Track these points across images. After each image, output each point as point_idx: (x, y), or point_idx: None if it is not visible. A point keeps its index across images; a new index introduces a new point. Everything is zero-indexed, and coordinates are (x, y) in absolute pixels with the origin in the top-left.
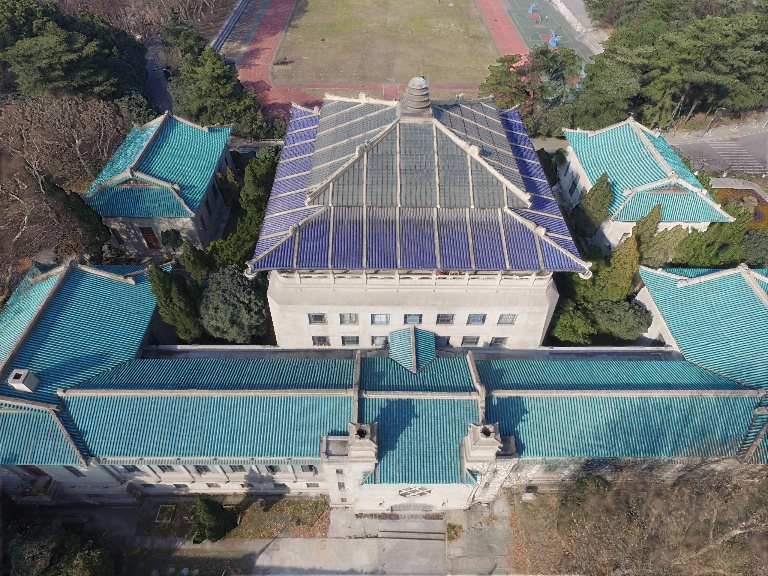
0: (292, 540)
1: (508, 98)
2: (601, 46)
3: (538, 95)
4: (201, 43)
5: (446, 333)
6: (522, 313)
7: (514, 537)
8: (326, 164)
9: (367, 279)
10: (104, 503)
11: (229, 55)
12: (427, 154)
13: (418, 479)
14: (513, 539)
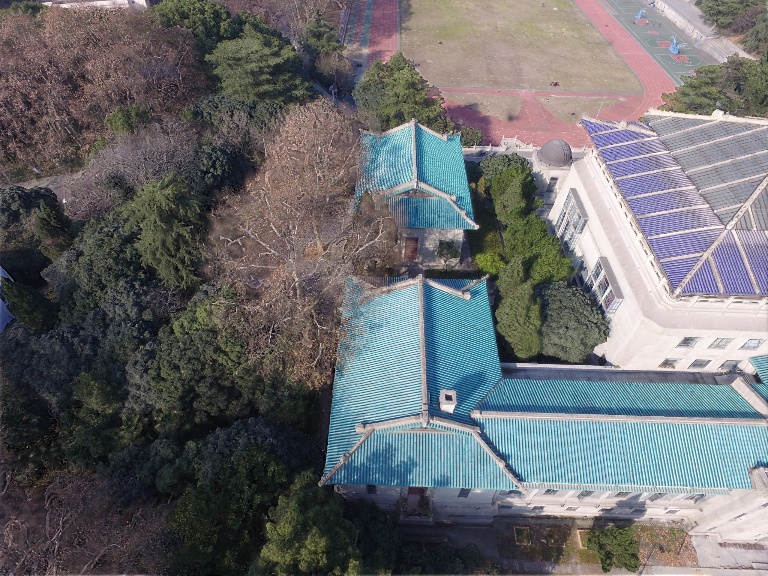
0: (664, 568)
1: (703, 109)
2: (728, 54)
3: (727, 106)
4: (342, 45)
5: None
6: None
7: None
8: (721, 185)
9: (764, 304)
10: (457, 523)
11: (353, 57)
12: None
13: None
14: None
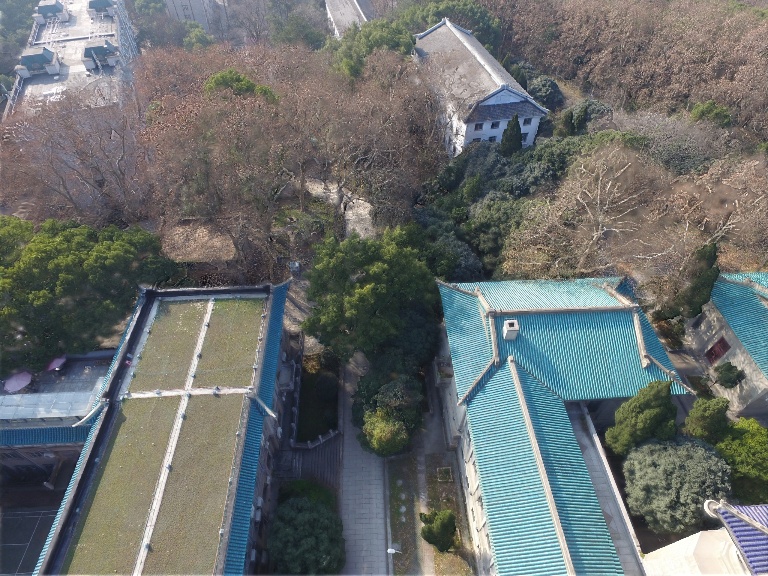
0: None
1: None
2: None
3: None
4: None
5: None
6: None
7: None
8: None
9: None
10: (445, 420)
11: None
12: None
13: None
14: None
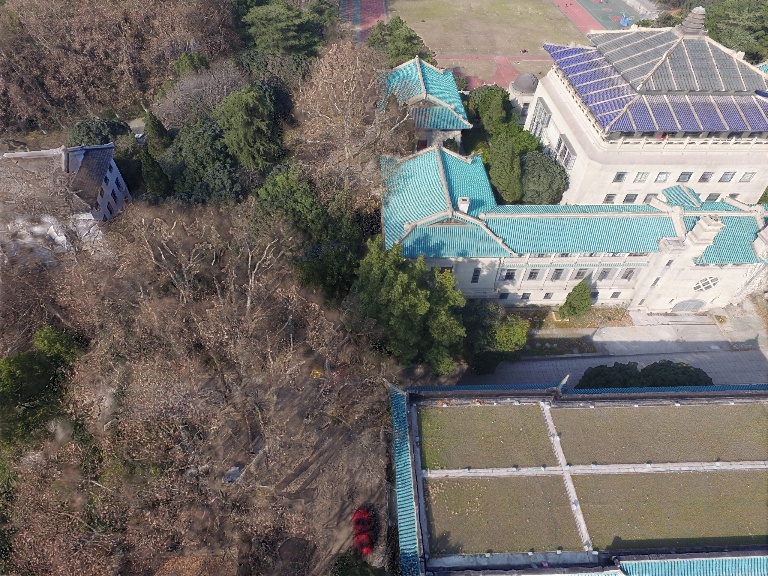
0: (611, 328)
1: None
2: None
3: None
4: (341, 20)
5: (700, 190)
6: (761, 171)
7: (763, 320)
8: (635, 67)
9: (665, 144)
10: None
11: None
12: (707, 58)
13: (730, 260)
14: (763, 321)
